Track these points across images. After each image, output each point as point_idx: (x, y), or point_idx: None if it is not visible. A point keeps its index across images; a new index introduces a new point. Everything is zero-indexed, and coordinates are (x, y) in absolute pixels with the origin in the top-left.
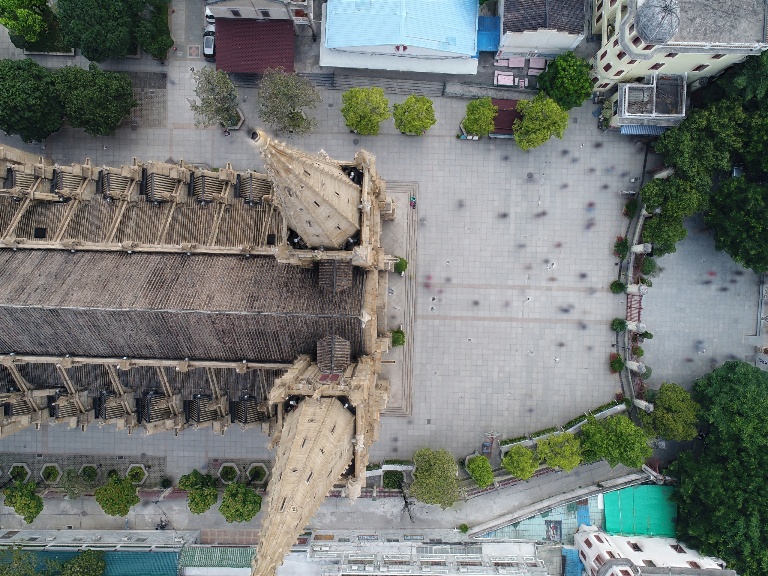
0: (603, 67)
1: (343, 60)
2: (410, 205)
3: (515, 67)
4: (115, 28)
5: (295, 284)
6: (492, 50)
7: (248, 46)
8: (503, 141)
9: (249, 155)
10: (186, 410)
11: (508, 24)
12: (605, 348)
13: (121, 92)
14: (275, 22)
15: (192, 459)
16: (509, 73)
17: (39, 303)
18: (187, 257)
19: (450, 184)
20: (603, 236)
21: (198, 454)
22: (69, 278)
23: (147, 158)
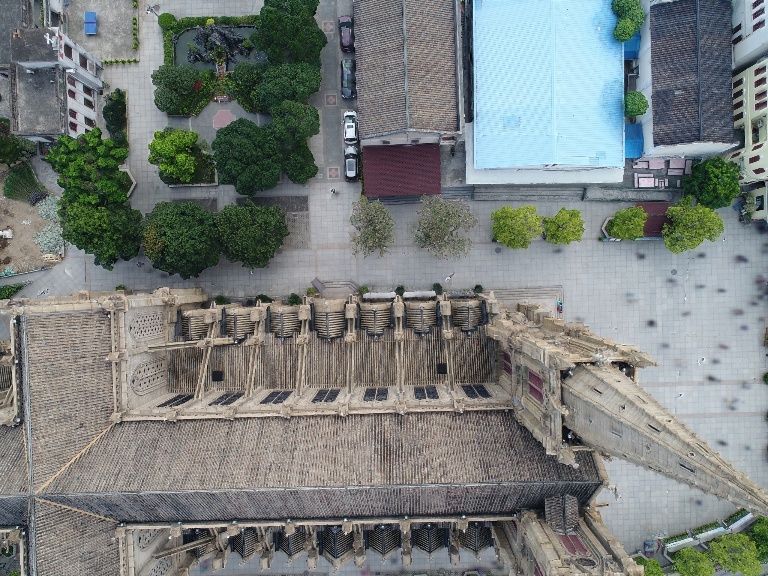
0: (753, 170)
1: (489, 177)
2: (557, 310)
3: (655, 169)
4: (270, 166)
5: (520, 444)
6: (636, 157)
7: (395, 170)
8: (645, 240)
9: (393, 270)
10: (365, 538)
11: (659, 136)
12: (761, 439)
13: (278, 226)
14: (422, 146)
15: (354, 574)
16: (649, 175)
17: (280, 485)
18: (400, 417)
19: (594, 286)
20: (752, 328)
21: (360, 568)
22: (296, 451)
23: (293, 280)
